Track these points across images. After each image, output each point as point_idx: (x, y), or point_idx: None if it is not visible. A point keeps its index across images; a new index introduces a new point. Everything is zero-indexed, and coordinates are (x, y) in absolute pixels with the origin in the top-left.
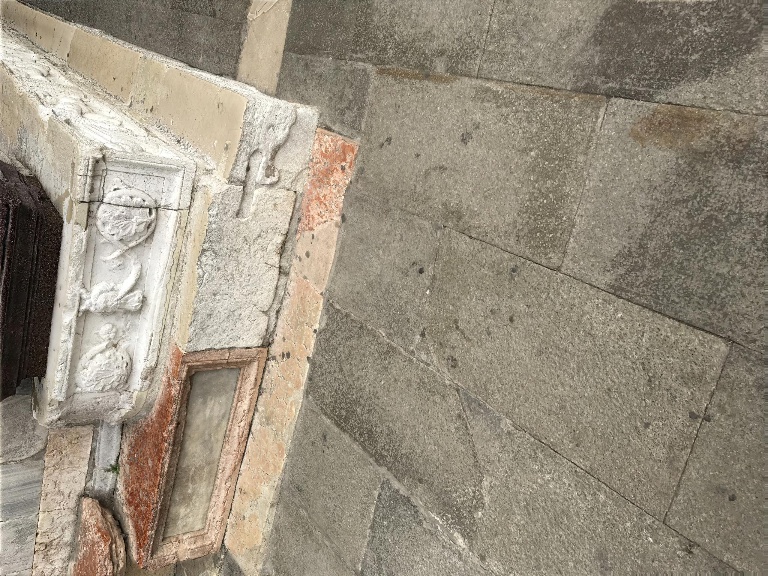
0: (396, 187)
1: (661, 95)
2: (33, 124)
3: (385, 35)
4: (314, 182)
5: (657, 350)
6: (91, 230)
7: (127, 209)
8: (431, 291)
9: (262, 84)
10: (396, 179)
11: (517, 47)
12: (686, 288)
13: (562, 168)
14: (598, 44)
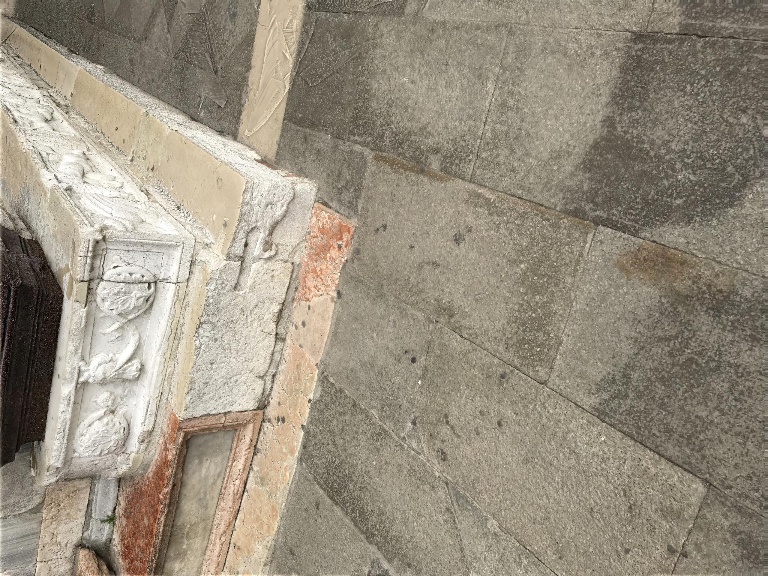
0: (390, 274)
1: (646, 232)
2: (35, 187)
3: (382, 123)
4: (311, 255)
5: (638, 479)
6: (91, 306)
7: (126, 285)
8: (422, 382)
9: (262, 149)
10: (390, 266)
11: (509, 159)
12: (667, 424)
13: (550, 286)
14: (587, 171)
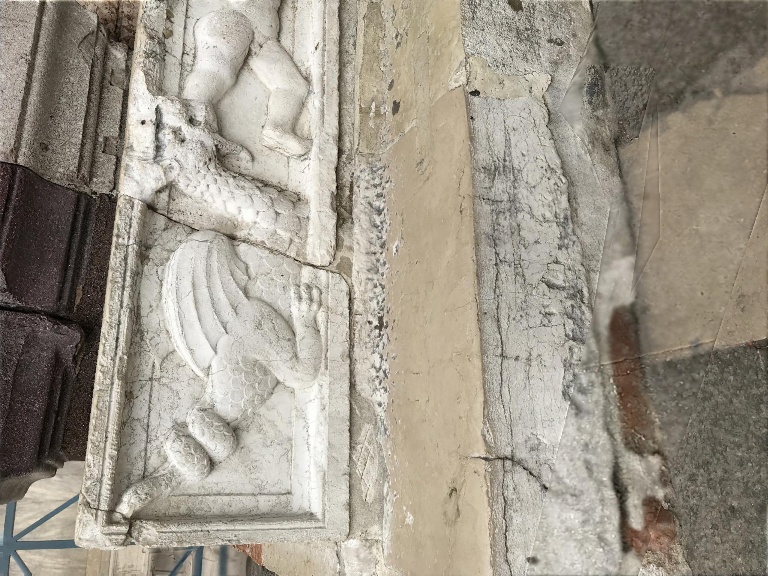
0: None
1: None
2: None
3: None
4: None
5: None
6: None
7: None
8: None
9: None
10: None
11: None
12: None
13: None
14: None
